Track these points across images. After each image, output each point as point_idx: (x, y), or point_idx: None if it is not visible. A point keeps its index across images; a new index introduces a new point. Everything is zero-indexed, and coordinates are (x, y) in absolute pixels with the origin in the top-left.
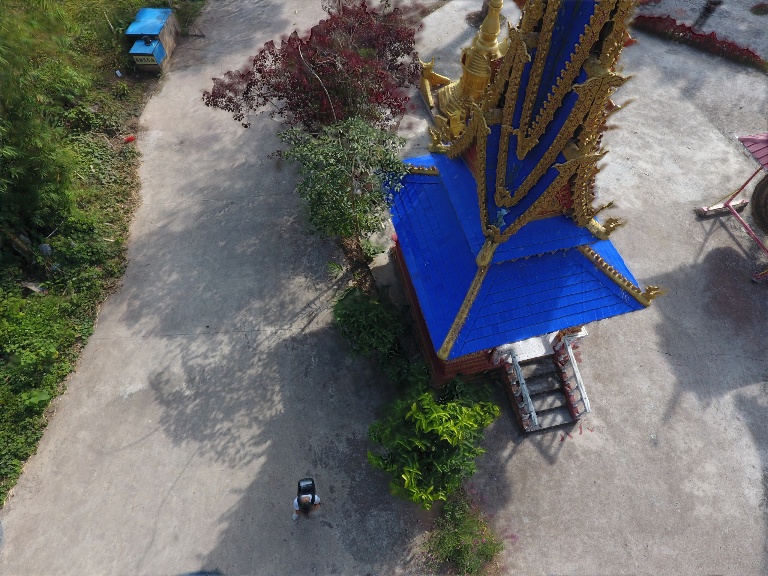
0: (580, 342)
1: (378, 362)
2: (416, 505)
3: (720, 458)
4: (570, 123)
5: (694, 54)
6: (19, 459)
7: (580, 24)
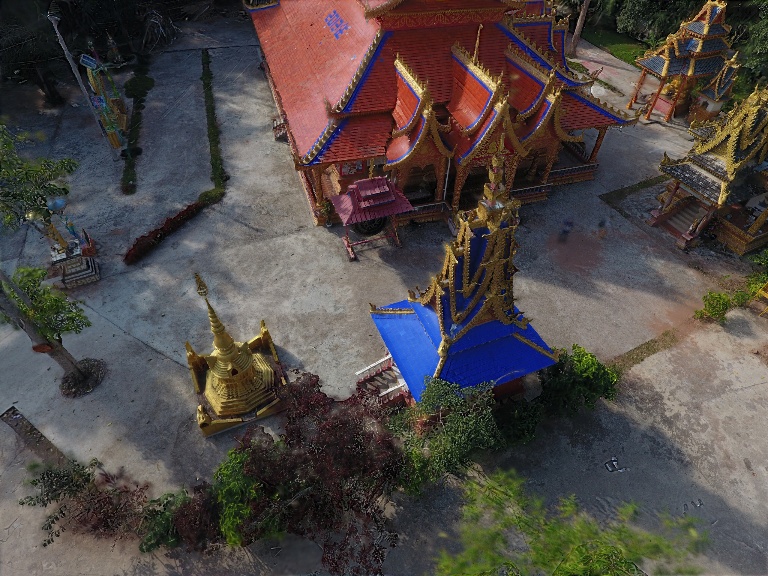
0: None
1: None
2: None
3: None
4: None
5: (181, 234)
6: None
7: None
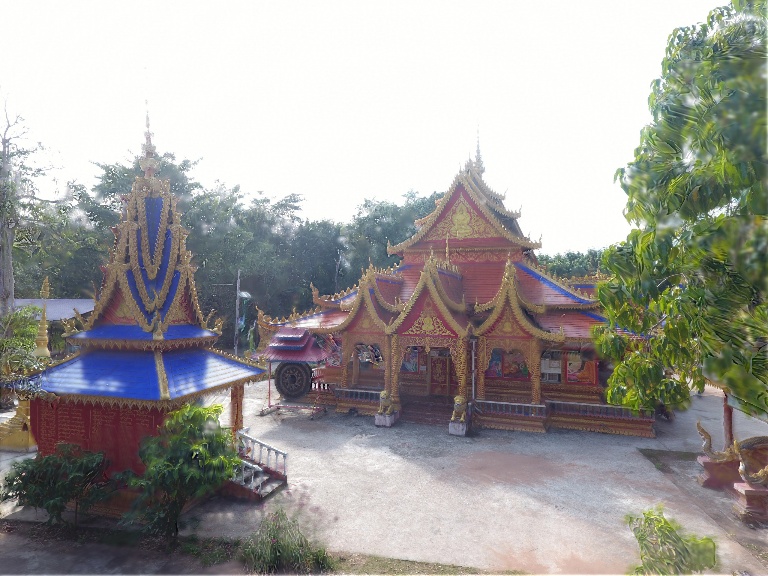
0: None
1: (76, 547)
2: (217, 575)
3: (370, 457)
4: (173, 250)
5: None
6: None
7: (158, 211)
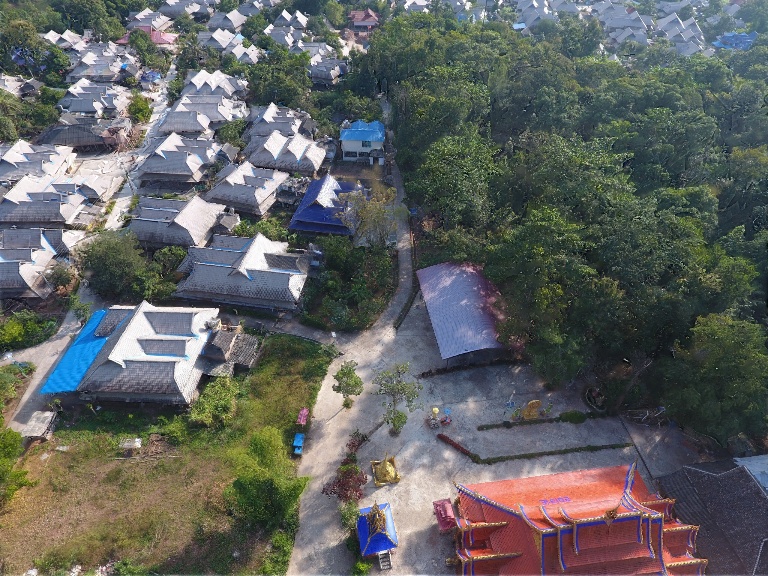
0: (397, 549)
1: None
2: None
3: None
4: None
5: (453, 450)
6: (286, 571)
7: None
